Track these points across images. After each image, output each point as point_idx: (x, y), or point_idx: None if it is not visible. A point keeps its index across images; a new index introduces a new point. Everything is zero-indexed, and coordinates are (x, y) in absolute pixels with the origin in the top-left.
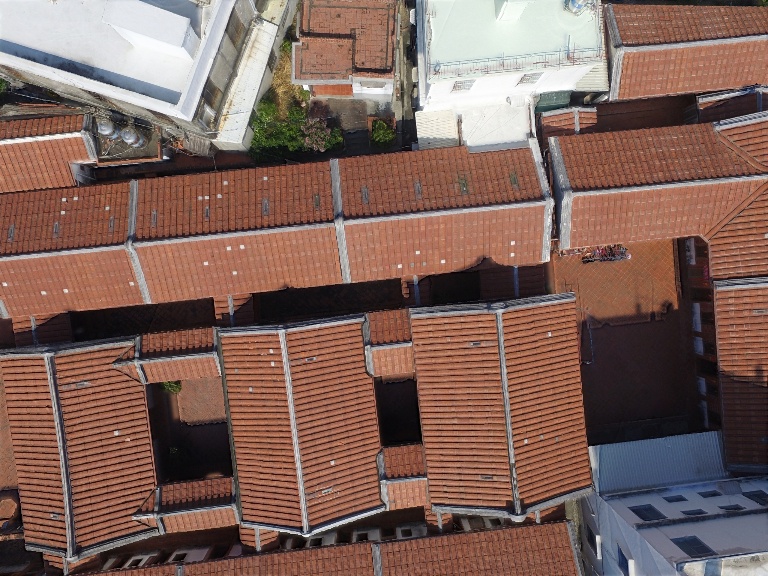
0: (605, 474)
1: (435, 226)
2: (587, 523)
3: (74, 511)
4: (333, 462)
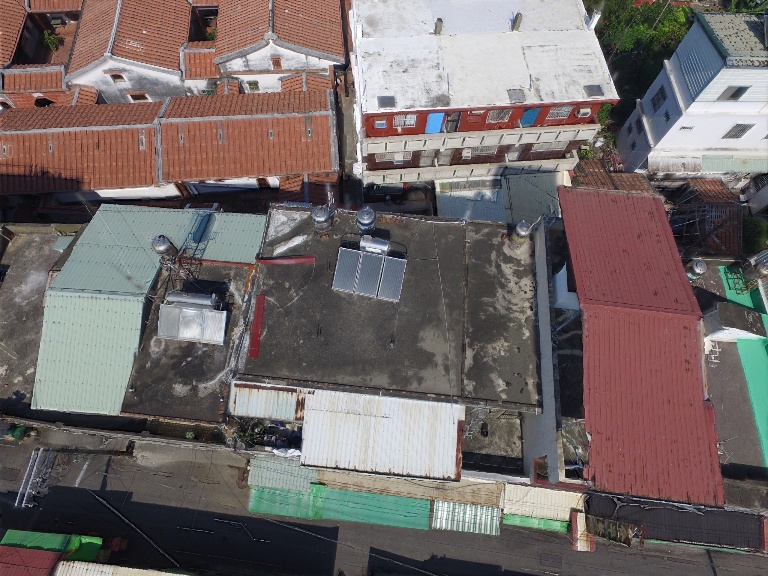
0: None
1: None
2: None
3: None
4: (145, 32)
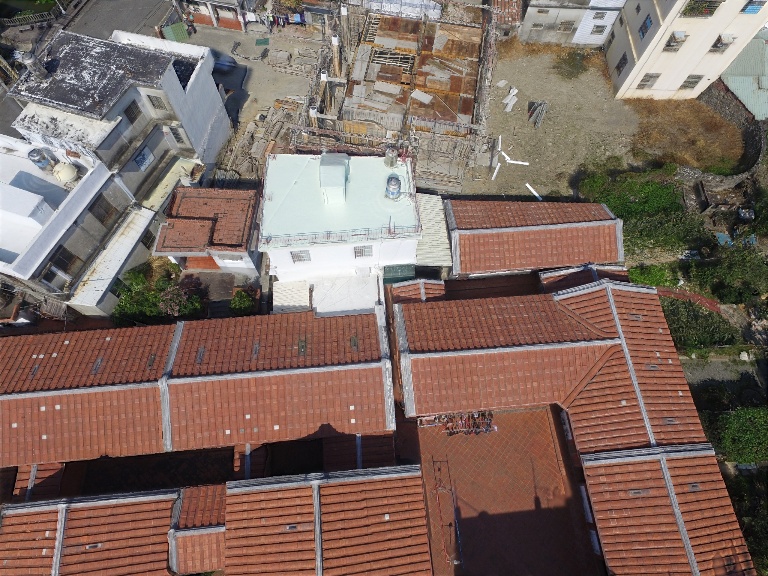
0: None
1: (266, 387)
2: None
3: None
4: None
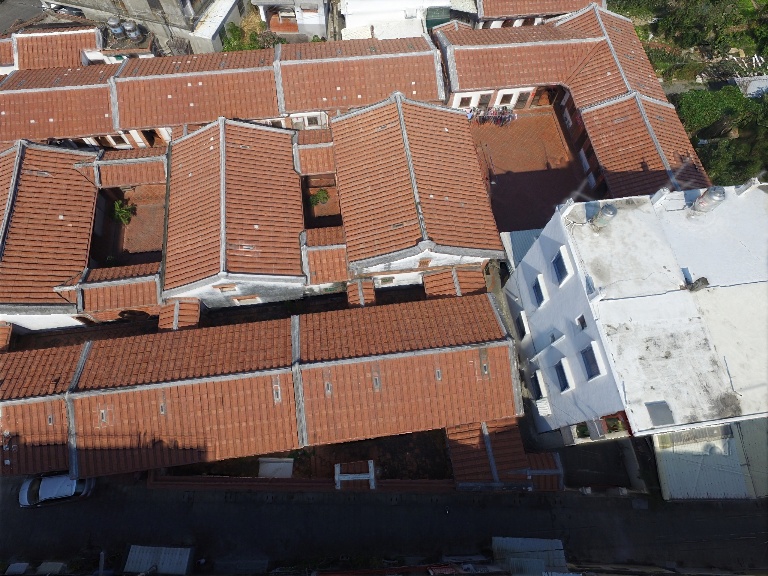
0: (518, 253)
1: (351, 68)
2: (516, 319)
3: None
4: (257, 226)
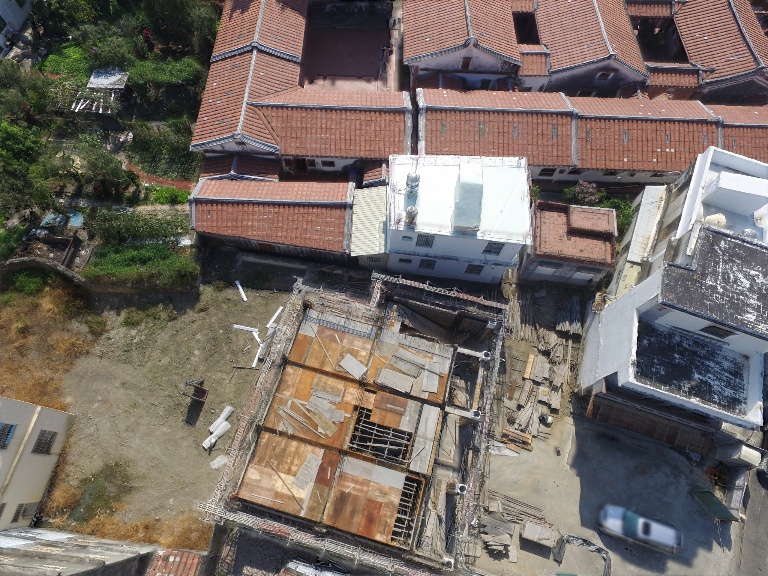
0: None
1: (505, 106)
2: None
3: (725, 1)
4: (569, 2)
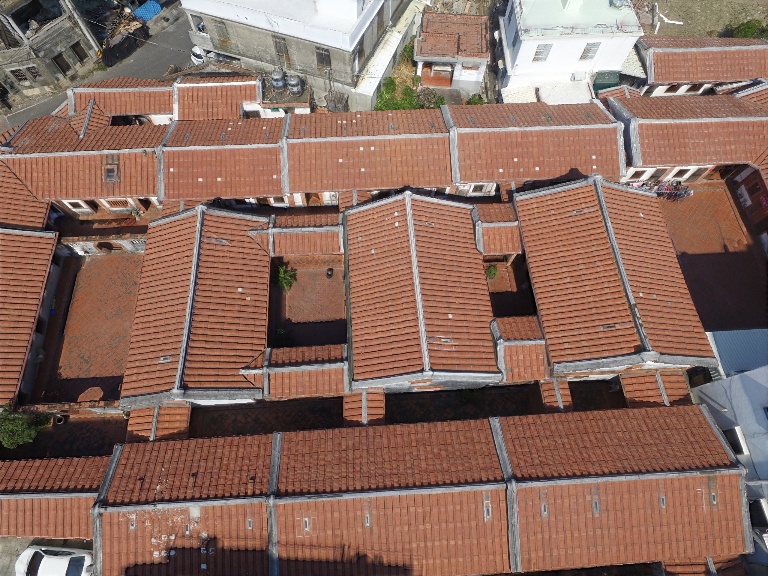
0: (726, 358)
1: (529, 139)
2: None
3: (189, 349)
4: (451, 315)
